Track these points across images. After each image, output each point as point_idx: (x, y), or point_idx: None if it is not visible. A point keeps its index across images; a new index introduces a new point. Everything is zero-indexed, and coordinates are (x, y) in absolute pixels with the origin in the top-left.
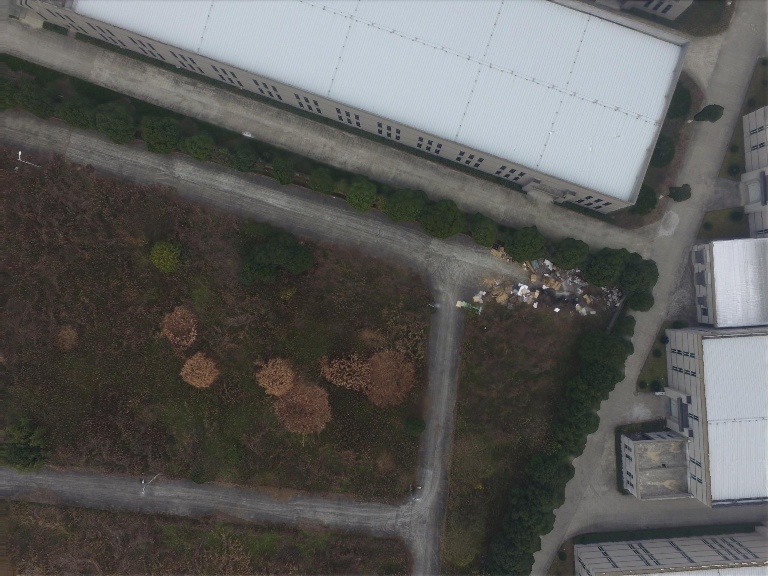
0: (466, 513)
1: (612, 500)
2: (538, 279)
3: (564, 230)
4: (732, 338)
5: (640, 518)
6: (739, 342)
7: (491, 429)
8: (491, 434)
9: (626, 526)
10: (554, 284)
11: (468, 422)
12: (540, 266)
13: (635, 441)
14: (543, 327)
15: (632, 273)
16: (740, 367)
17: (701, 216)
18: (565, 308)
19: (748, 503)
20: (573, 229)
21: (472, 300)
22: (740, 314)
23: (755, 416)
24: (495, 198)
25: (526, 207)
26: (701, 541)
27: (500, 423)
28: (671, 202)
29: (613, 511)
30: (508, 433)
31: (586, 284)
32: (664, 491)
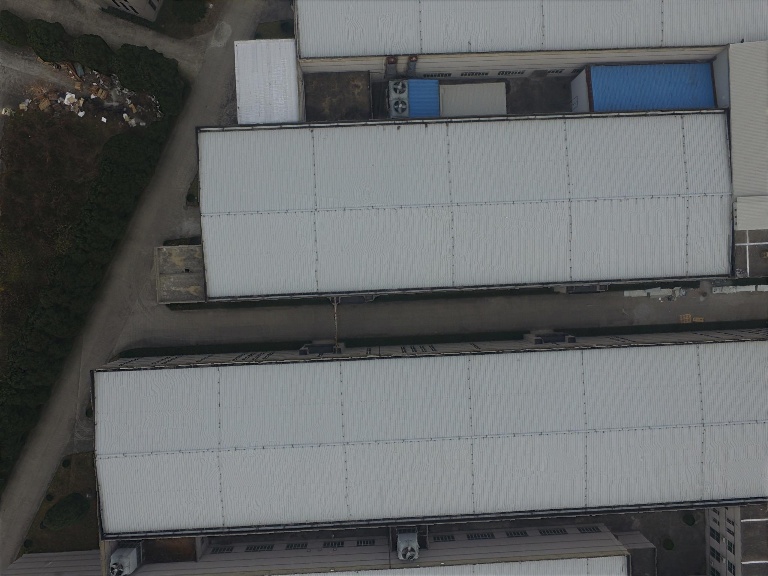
0: (2, 322)
1: (161, 315)
2: (86, 88)
3: (113, 38)
4: (233, 132)
5: (190, 334)
6: (240, 136)
7: (34, 239)
8: (35, 245)
9: (175, 342)
10: (98, 92)
11: (4, 229)
12: (88, 75)
13: (161, 246)
14: (90, 137)
15: (136, 64)
16: (239, 161)
17: (254, 28)
18: (110, 117)
19: (246, 299)
20: (122, 37)
21: (18, 108)
22: (263, 116)
23: (250, 209)
24: (42, 3)
25: (74, 13)
26: (240, 354)
27: (44, 233)
28: (223, 12)
29: (162, 327)
30: (44, 240)
31: (133, 94)
32: (189, 297)
